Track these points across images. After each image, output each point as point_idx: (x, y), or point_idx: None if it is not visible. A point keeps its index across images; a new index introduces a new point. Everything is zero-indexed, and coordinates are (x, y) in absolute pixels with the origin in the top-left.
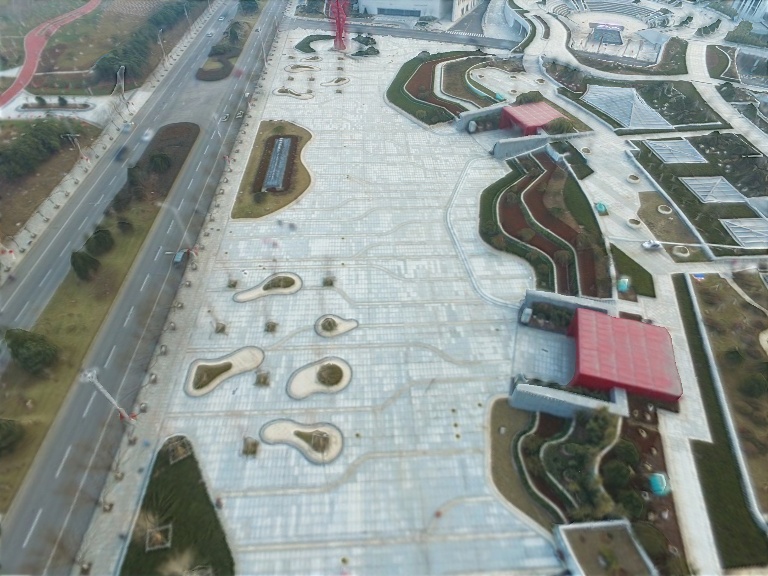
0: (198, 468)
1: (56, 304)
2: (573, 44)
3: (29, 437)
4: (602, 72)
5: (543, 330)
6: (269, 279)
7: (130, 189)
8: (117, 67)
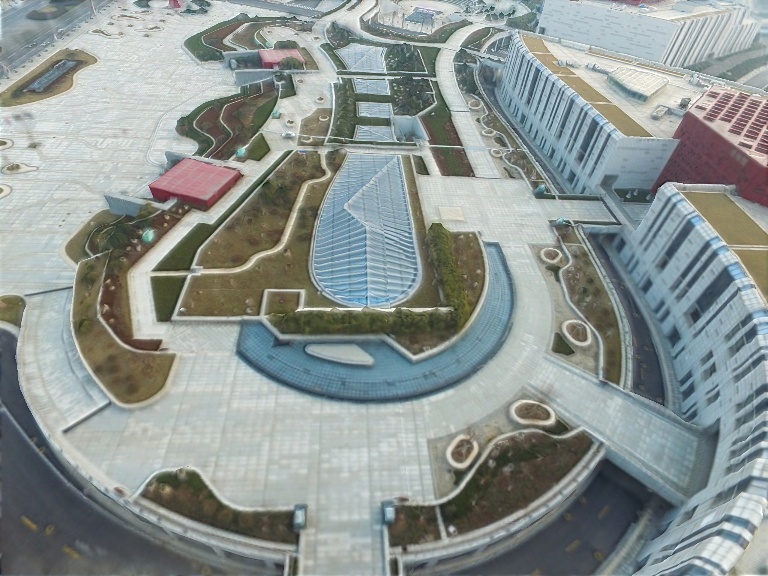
0: None
1: None
2: (383, 20)
3: None
4: (373, 36)
5: None
6: None
7: None
8: None
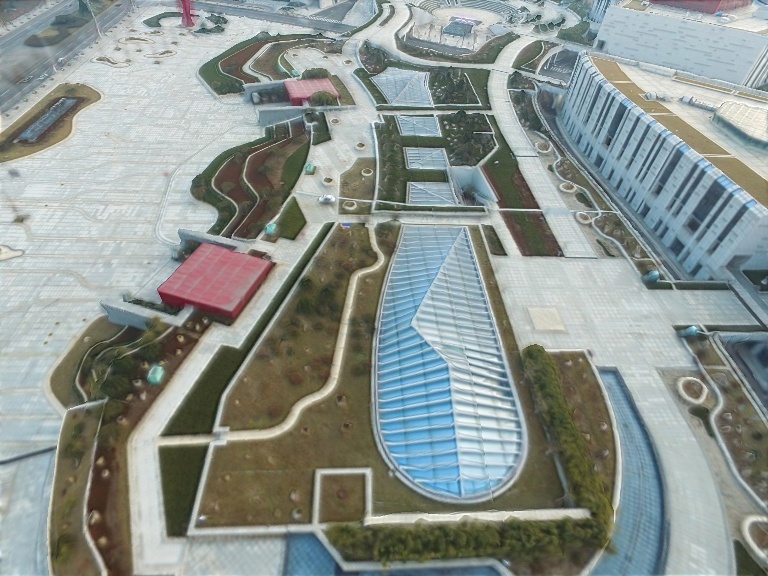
0: None
1: None
2: (418, 34)
3: None
4: (412, 57)
5: None
6: None
7: None
8: None
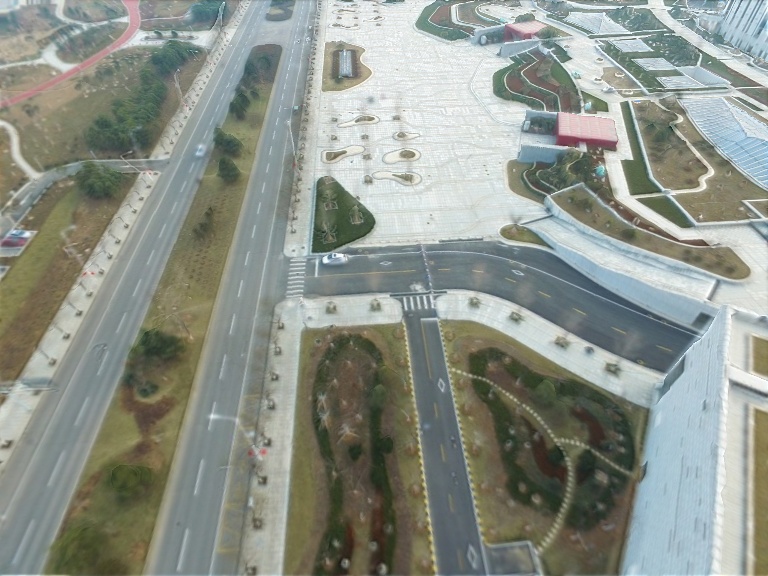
0: (342, 187)
1: (226, 130)
2: None
3: (241, 177)
4: (581, 5)
5: (538, 134)
6: (358, 118)
7: (248, 77)
8: (209, 10)
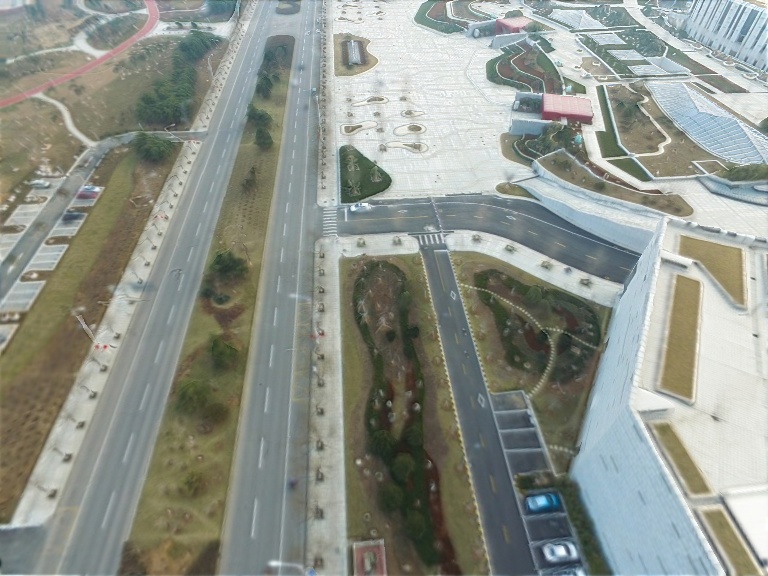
0: (361, 153)
1: None
2: None
3: (274, 145)
4: (564, 3)
5: (526, 112)
6: (369, 98)
7: (268, 64)
8: (224, 4)
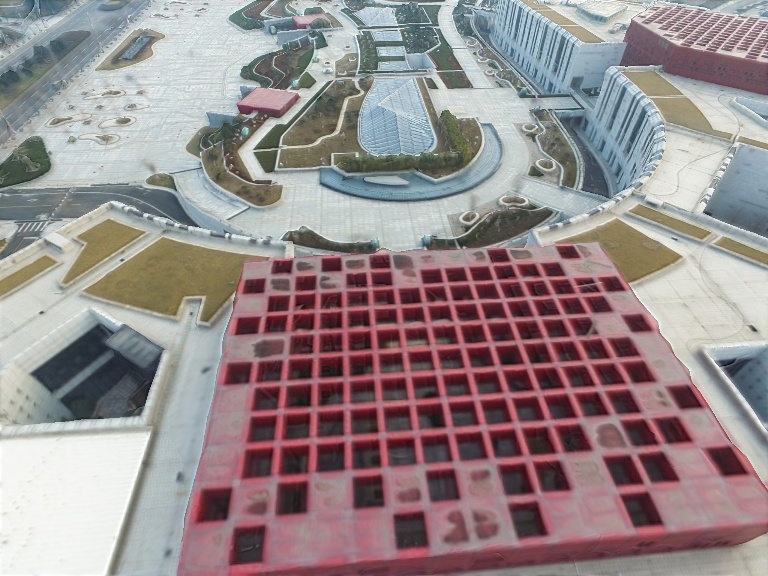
0: (43, 145)
1: None
2: None
3: None
4: (384, 1)
5: None
6: None
7: (34, 58)
8: None
